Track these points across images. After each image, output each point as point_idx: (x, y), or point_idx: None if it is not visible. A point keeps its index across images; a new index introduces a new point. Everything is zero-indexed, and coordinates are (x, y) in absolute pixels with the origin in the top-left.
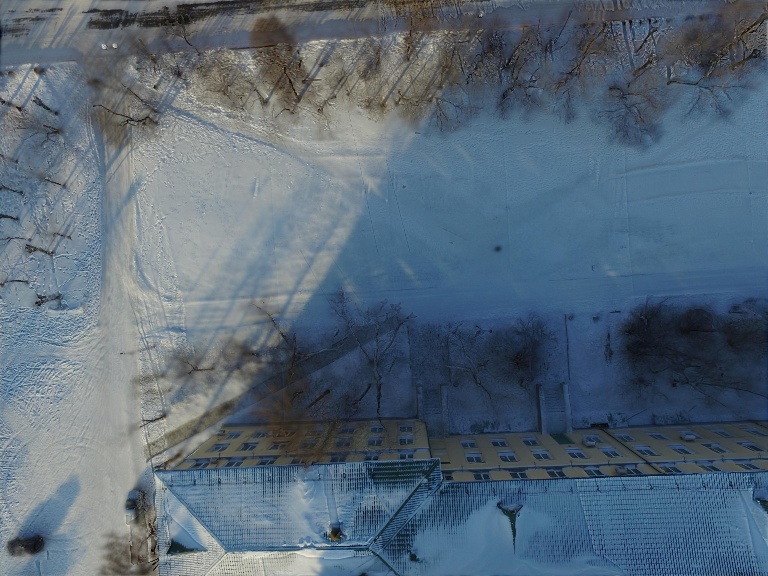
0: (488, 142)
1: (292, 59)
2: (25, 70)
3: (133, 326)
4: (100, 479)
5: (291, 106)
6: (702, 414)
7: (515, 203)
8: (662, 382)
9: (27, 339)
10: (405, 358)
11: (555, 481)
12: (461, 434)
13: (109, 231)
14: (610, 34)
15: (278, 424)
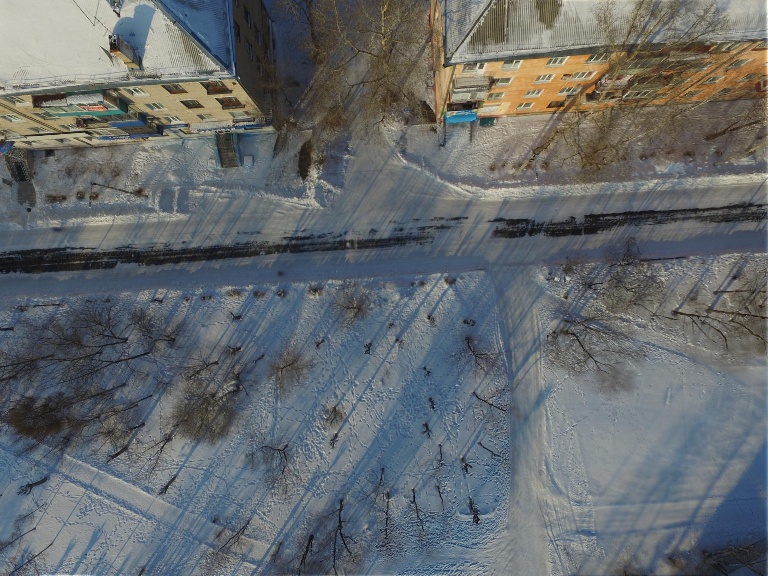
0: None
1: (705, 271)
2: (434, 279)
3: (542, 529)
4: None
5: None
6: None
7: None
8: None
9: (436, 542)
10: None
11: None
12: None
13: (517, 436)
14: None
15: None
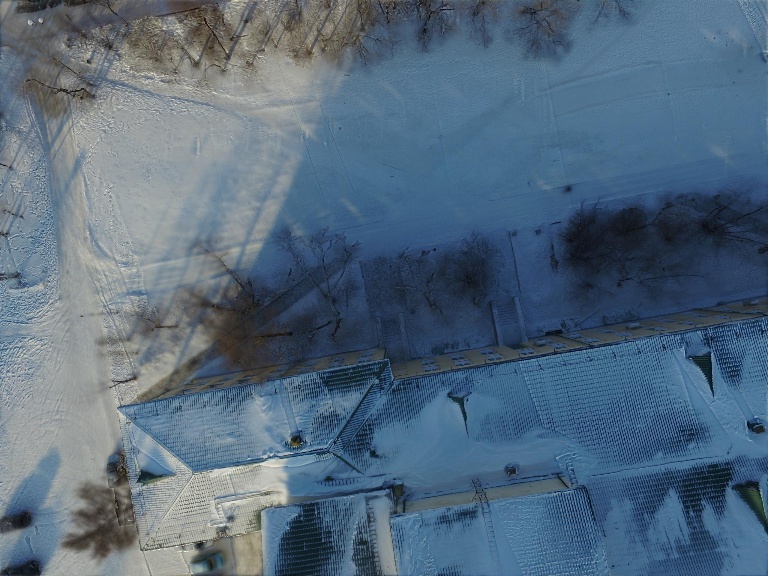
0: (415, 76)
1: (218, 19)
2: None
3: (94, 296)
4: (79, 449)
5: (222, 64)
6: (650, 309)
7: (448, 131)
8: (608, 283)
9: None
10: (361, 292)
11: (499, 366)
12: (423, 357)
13: (60, 206)
14: None
15: (245, 370)
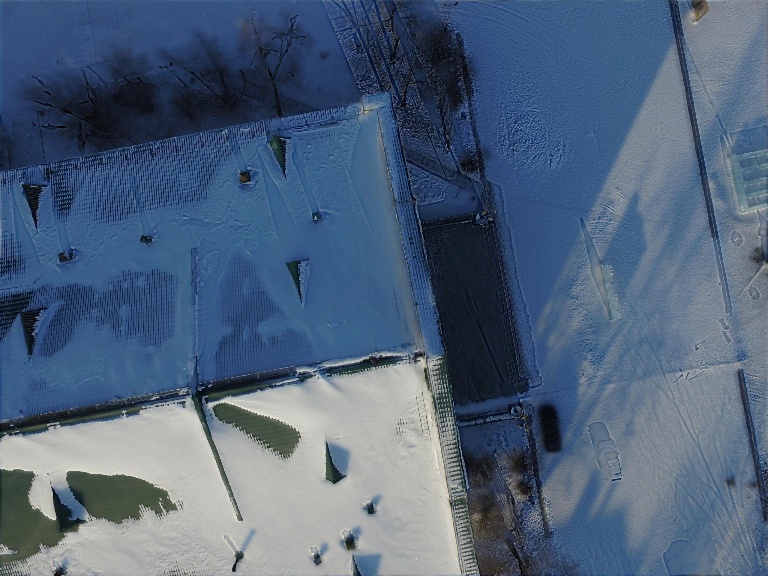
0: None
1: None
2: None
3: None
4: None
5: None
6: None
7: None
8: None
9: None
10: None
11: None
12: None
13: None
14: None
15: None
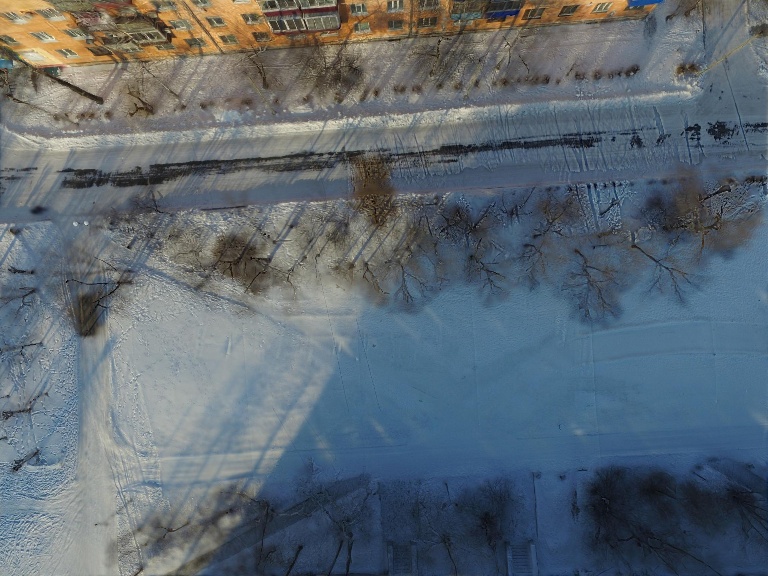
0: (456, 302)
1: (263, 220)
2: (1, 230)
3: (110, 480)
4: None
5: (262, 266)
6: (668, 572)
7: (483, 363)
8: (628, 542)
9: (7, 493)
10: (376, 515)
11: None
12: None
13: (85, 387)
14: (575, 196)
15: None
